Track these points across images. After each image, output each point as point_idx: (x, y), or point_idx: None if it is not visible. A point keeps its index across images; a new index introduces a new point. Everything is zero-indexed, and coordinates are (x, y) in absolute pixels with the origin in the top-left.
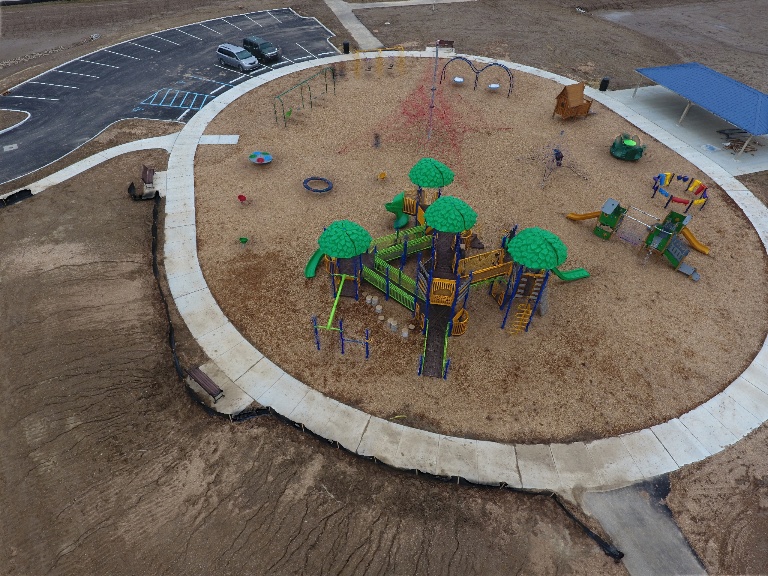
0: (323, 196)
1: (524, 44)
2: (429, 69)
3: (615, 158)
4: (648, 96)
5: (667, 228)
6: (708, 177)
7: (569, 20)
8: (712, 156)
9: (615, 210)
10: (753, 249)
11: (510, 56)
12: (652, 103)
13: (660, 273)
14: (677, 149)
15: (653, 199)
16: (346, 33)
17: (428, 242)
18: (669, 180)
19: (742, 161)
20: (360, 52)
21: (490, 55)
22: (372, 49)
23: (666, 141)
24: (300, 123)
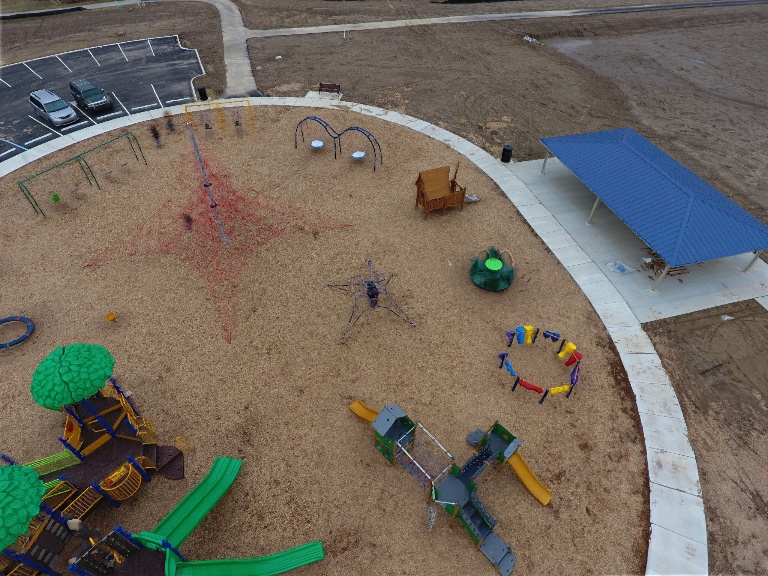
0: (8, 352)
1: (432, 88)
2: (293, 125)
3: (474, 284)
4: (563, 171)
5: (472, 466)
6: (601, 324)
7: (505, 54)
8: (619, 282)
9: (392, 428)
10: (629, 492)
11: (407, 105)
12: (564, 183)
13: (451, 550)
14: (572, 267)
15: (501, 370)
16: (221, 71)
17: (78, 476)
18: (533, 336)
19: (661, 293)
20: (221, 98)
21: (383, 104)
22: (239, 94)
23: (561, 252)
24: (70, 212)
